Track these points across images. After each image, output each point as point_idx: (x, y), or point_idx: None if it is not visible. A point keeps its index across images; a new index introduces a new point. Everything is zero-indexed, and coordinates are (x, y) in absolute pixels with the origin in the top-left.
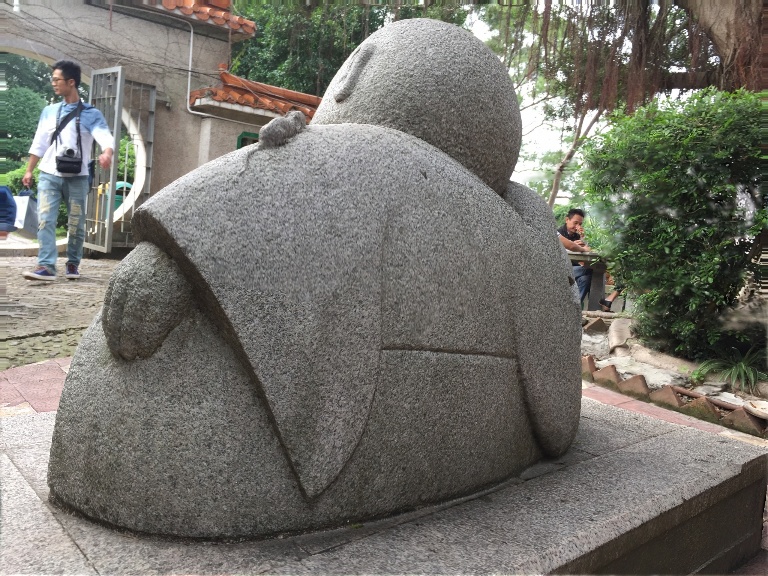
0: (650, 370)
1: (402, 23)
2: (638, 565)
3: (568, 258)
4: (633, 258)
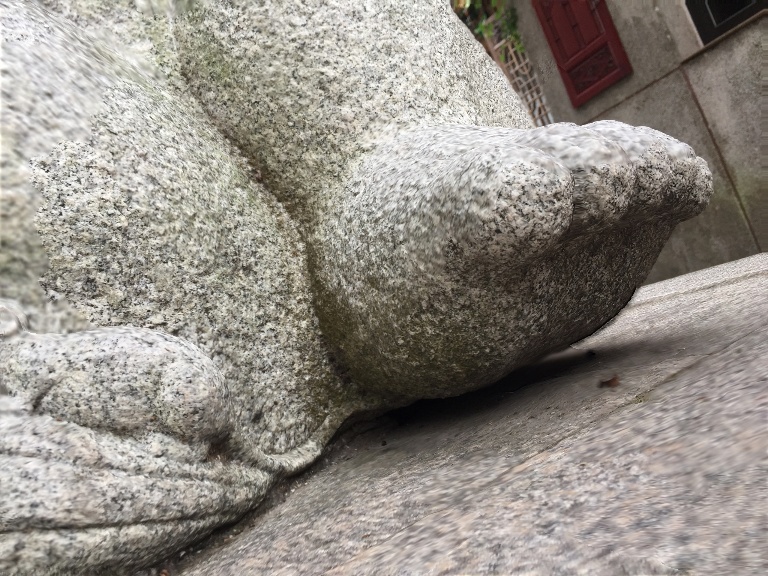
0: None
1: None
2: None
3: None
4: None
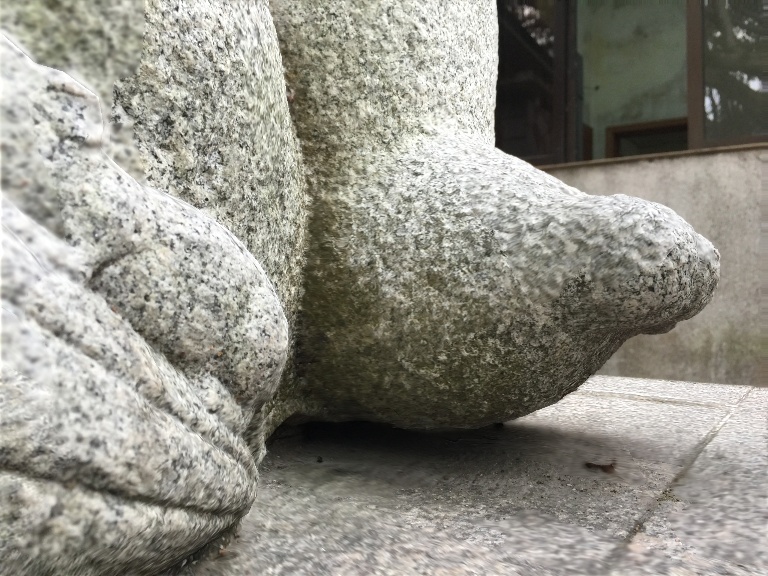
0: None
1: None
2: None
3: None
4: None
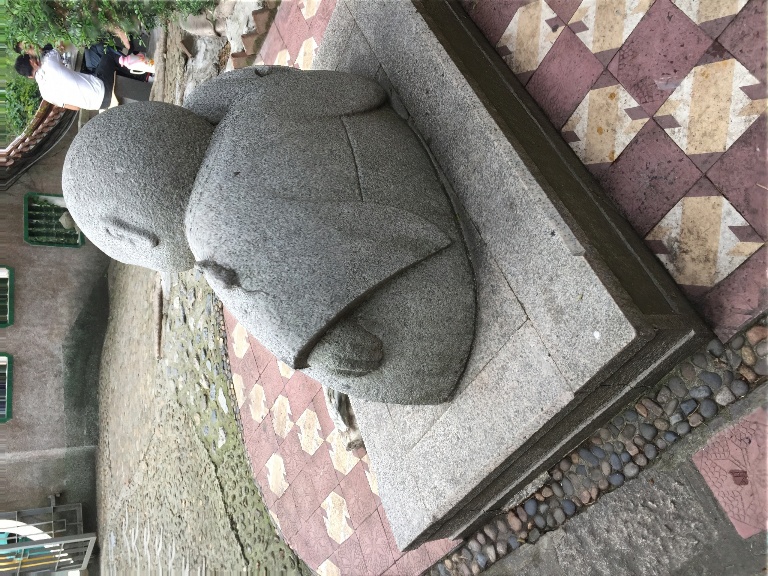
0: (243, 4)
1: (77, 195)
2: (459, 48)
3: (236, 72)
4: (141, 5)
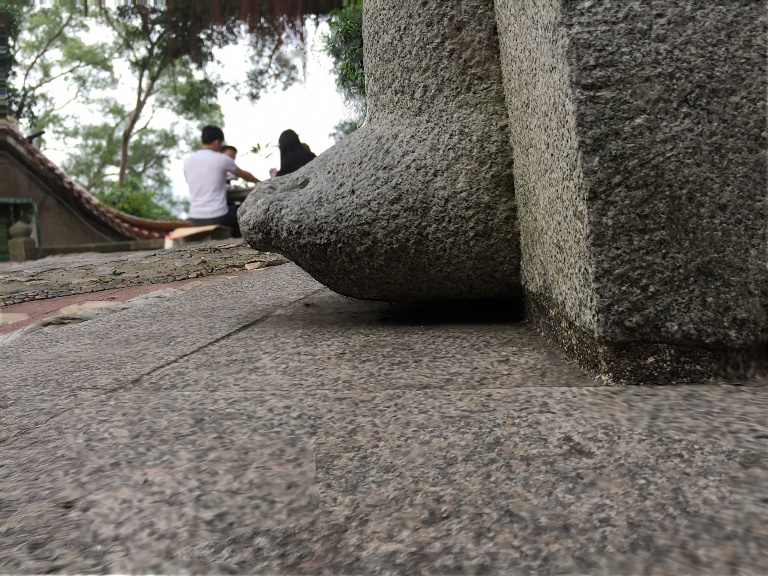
0: None
1: None
2: None
3: None
4: None
